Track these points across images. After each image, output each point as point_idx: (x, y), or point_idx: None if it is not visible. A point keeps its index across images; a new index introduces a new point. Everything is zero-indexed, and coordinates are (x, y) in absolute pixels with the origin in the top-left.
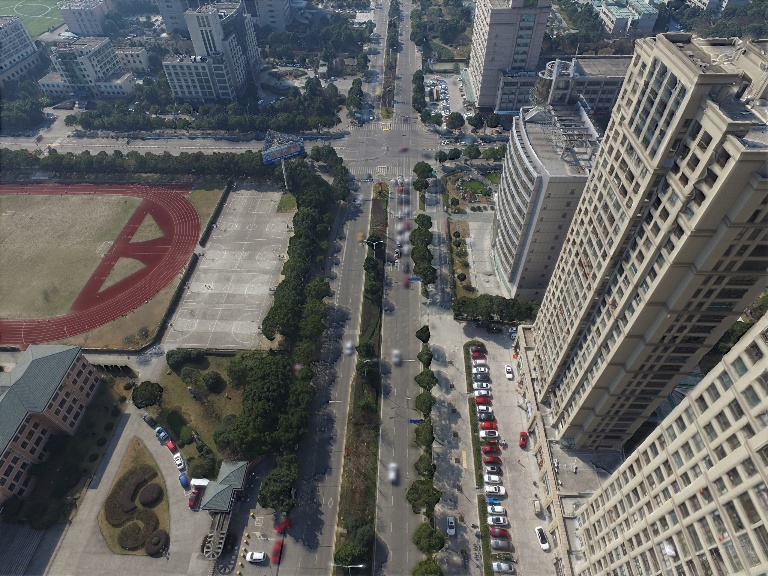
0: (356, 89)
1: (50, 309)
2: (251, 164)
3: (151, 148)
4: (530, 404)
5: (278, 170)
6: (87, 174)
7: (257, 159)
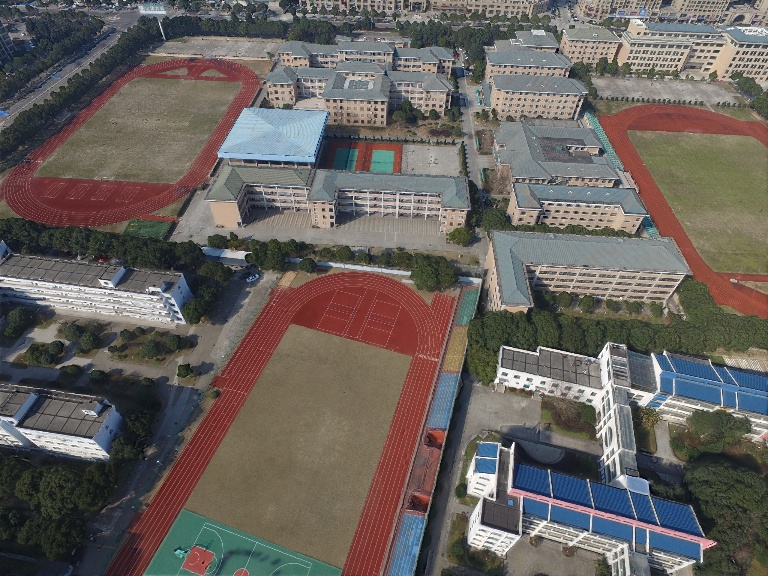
0: (70, 9)
1: (235, 86)
2: (142, 34)
3: (60, 83)
4: (327, 1)
5: (154, 30)
6: (79, 100)
7: (141, 30)
